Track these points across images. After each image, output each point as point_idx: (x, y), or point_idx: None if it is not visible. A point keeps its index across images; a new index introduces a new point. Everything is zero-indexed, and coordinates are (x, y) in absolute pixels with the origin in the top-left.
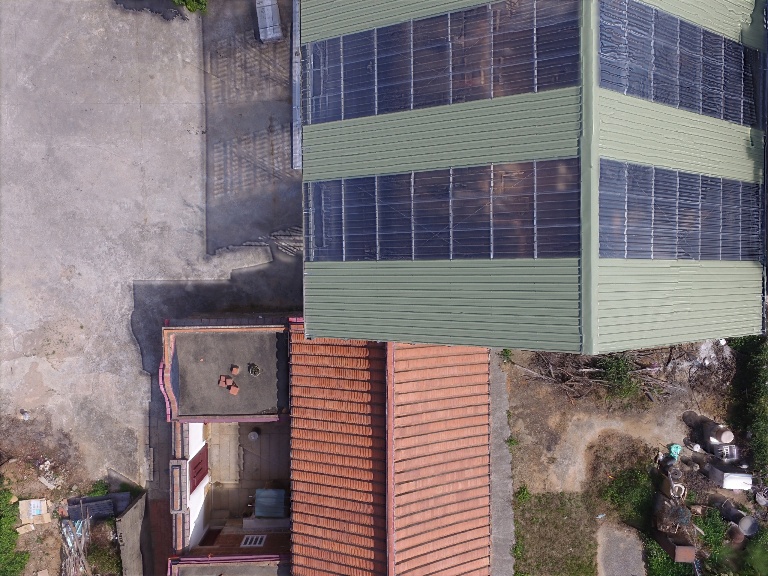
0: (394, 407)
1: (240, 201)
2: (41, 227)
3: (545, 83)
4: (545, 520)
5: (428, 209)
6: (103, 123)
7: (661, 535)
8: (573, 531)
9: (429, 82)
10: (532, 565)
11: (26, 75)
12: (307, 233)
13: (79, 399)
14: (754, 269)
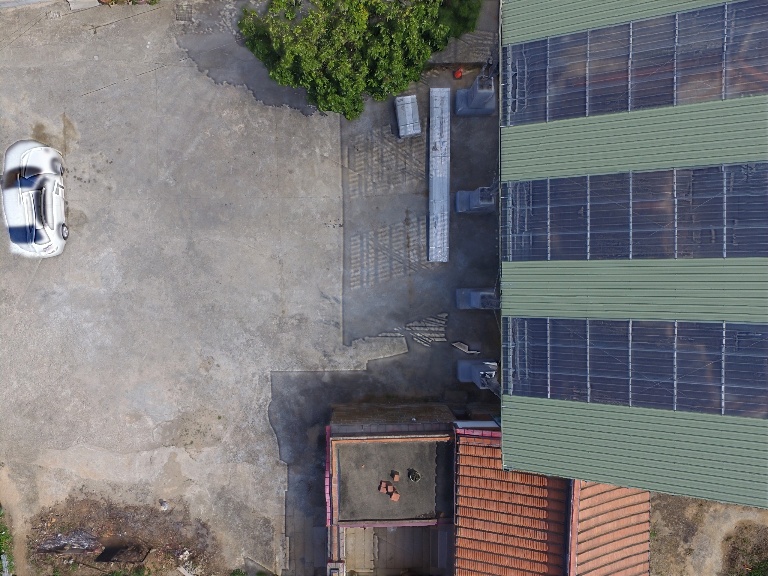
0: None
1: (376, 293)
2: (180, 319)
3: None
4: None
5: (648, 358)
6: (242, 217)
7: None
8: None
9: (651, 234)
10: None
11: (167, 170)
12: (506, 366)
13: (217, 489)
14: None
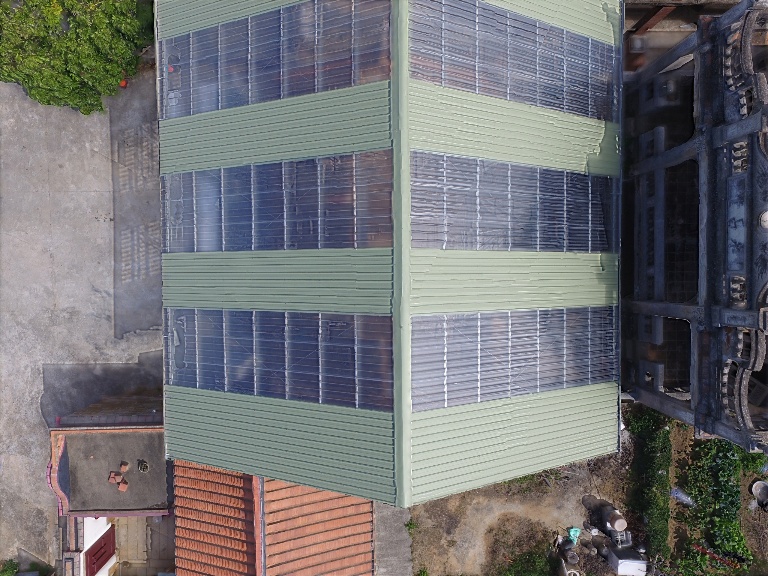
0: (266, 515)
1: (147, 286)
2: None
3: (363, 240)
4: None
5: (267, 348)
6: (13, 211)
7: None
8: None
9: (267, 226)
10: None
11: None
12: (167, 357)
13: None
14: (608, 389)
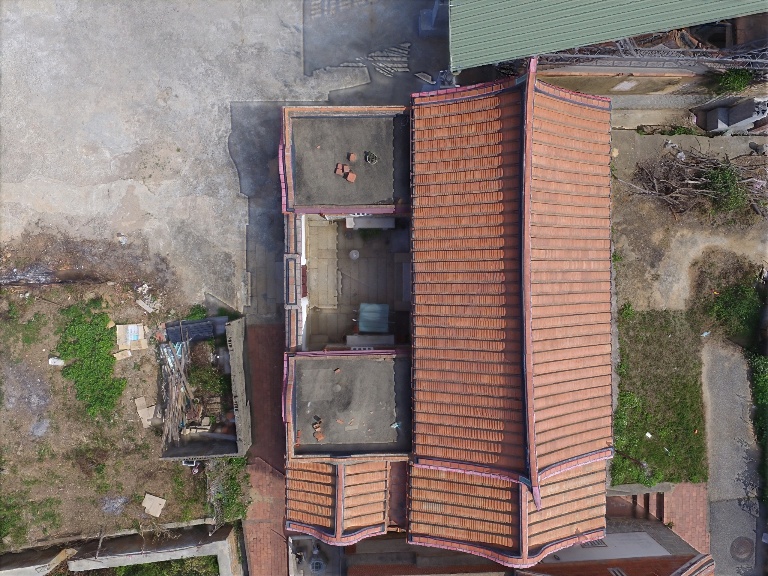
0: None
1: (337, 22)
2: (137, 49)
3: None
4: (649, 338)
5: None
6: None
7: None
8: (678, 350)
9: None
10: (637, 384)
11: None
12: None
13: (176, 223)
14: None
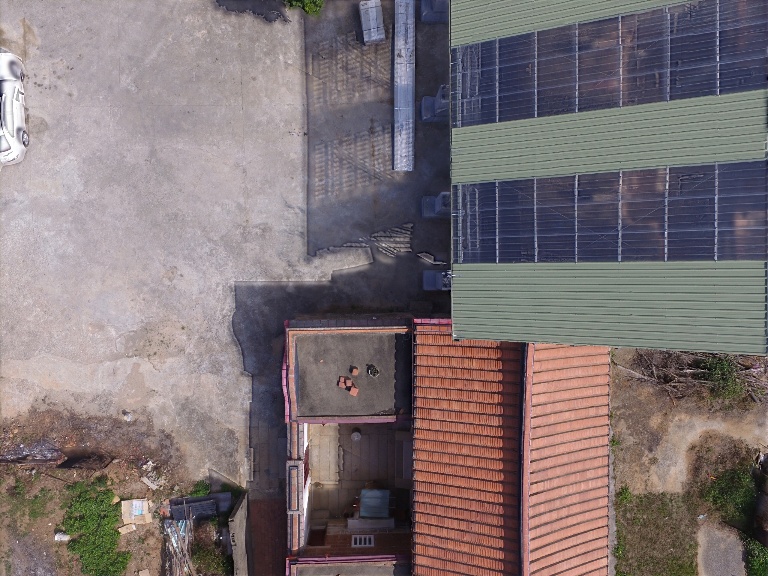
0: None
1: (341, 202)
2: (143, 228)
3: (729, 86)
4: (646, 520)
5: (594, 211)
6: (205, 125)
7: (766, 535)
8: (674, 531)
9: (596, 85)
10: (633, 565)
11: (129, 77)
12: (456, 235)
13: (180, 400)
14: None
